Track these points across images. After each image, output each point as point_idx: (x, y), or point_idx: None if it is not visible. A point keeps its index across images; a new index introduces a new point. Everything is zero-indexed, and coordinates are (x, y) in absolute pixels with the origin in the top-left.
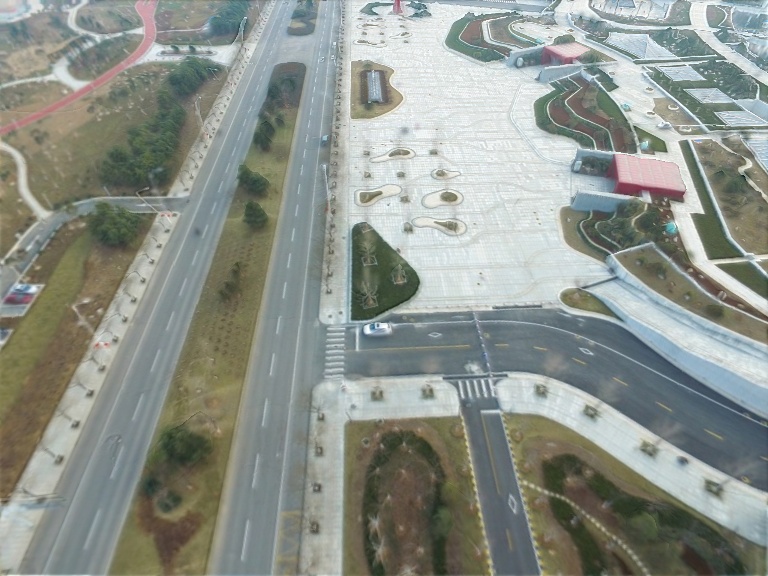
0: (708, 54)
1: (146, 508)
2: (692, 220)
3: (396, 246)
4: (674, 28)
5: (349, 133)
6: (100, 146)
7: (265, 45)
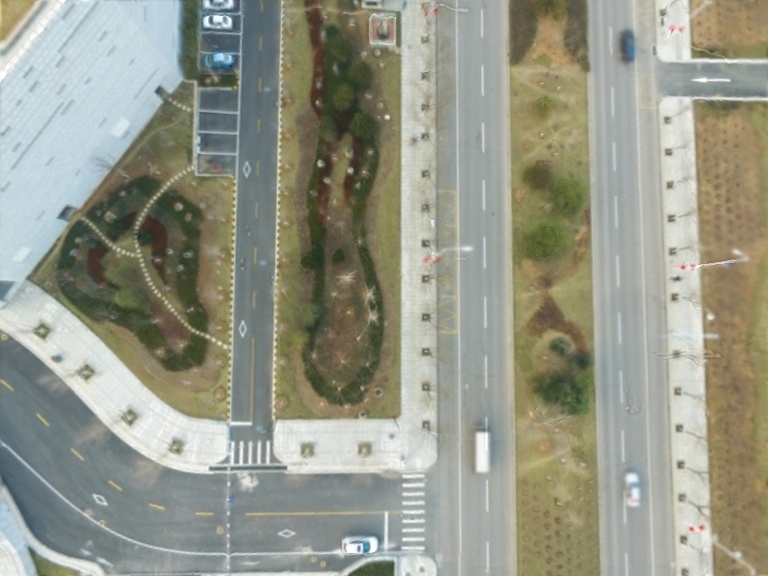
0: None
1: (579, 342)
2: None
3: None
4: None
5: None
6: None
7: None
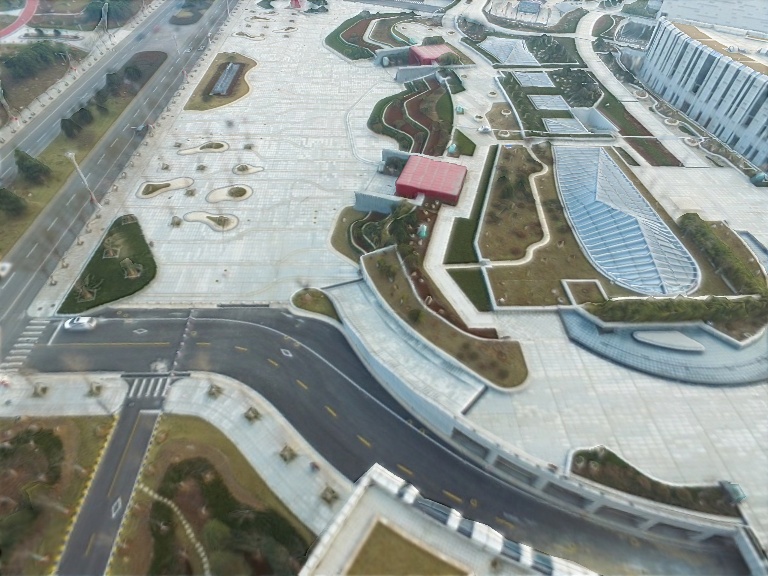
0: (570, 62)
1: None
2: (452, 224)
3: (153, 240)
4: (556, 35)
5: (172, 124)
6: None
7: (139, 33)
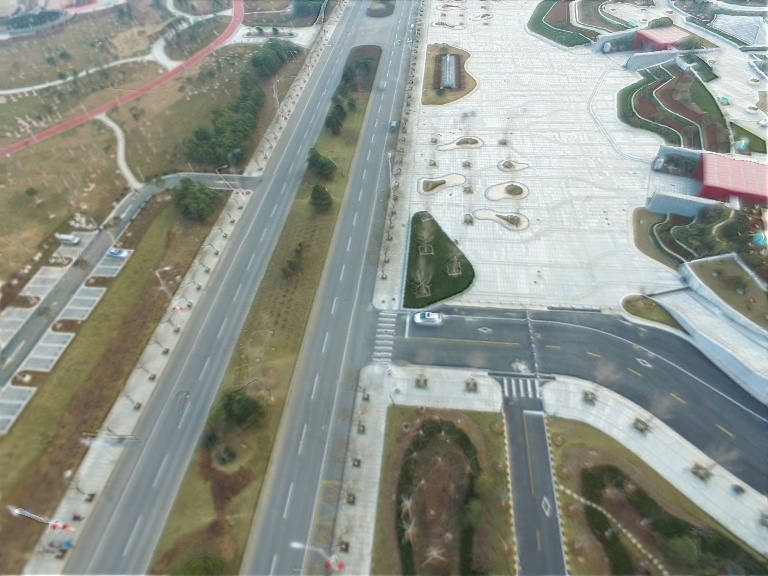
0: None
1: (206, 459)
2: None
3: (454, 237)
4: None
5: (418, 119)
6: (187, 124)
7: (344, 27)
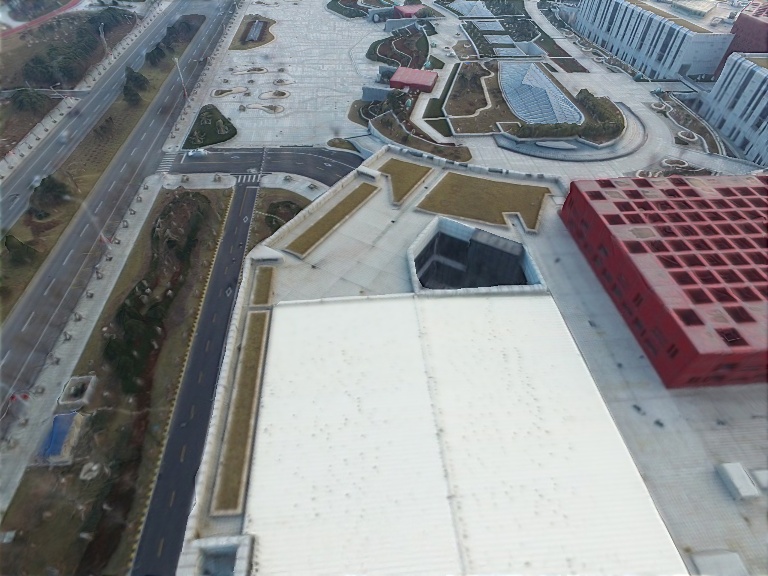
0: (518, 14)
1: (28, 218)
2: (428, 101)
3: (229, 117)
4: None
5: (223, 58)
6: (27, 59)
7: (178, 3)
